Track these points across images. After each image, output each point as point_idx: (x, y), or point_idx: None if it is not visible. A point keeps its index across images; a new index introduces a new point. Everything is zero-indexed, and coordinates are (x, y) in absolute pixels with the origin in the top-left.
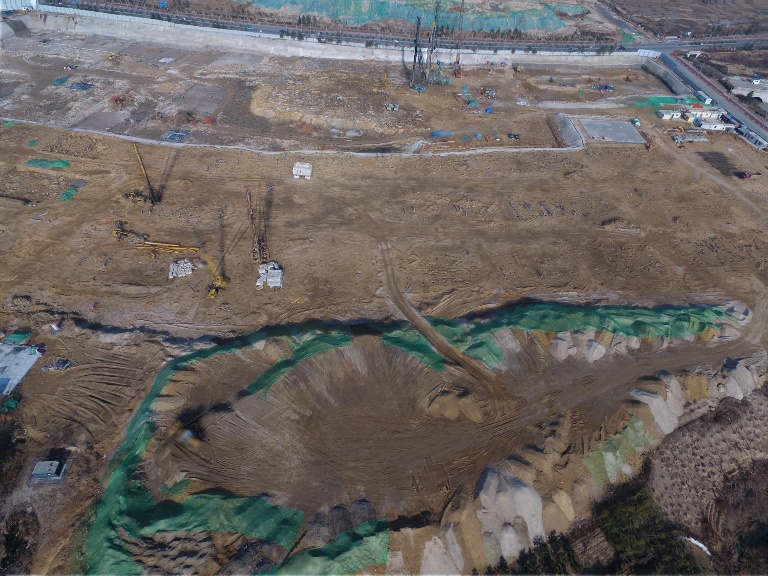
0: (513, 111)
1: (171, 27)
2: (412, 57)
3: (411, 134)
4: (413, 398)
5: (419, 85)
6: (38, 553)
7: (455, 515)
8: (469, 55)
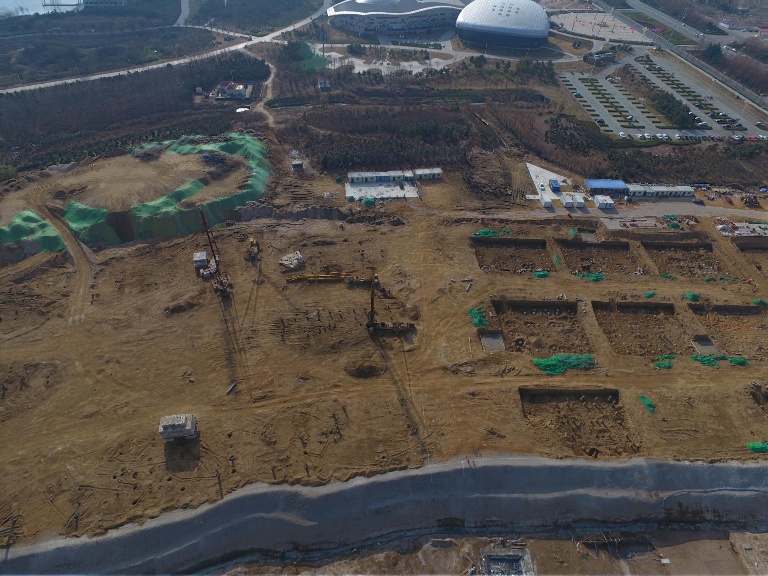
0: None
1: None
2: None
3: None
4: (96, 188)
5: None
6: (283, 153)
7: None
8: None
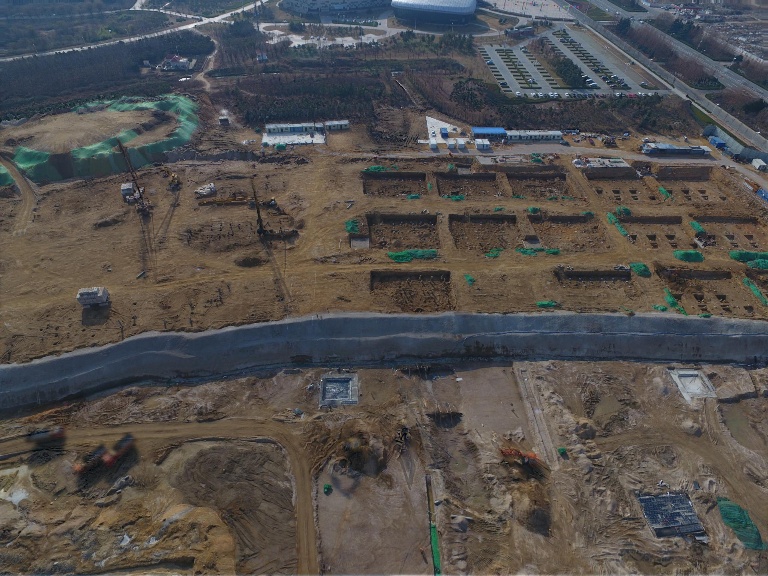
0: None
1: None
2: None
3: None
4: (42, 137)
5: None
6: None
7: None
8: None
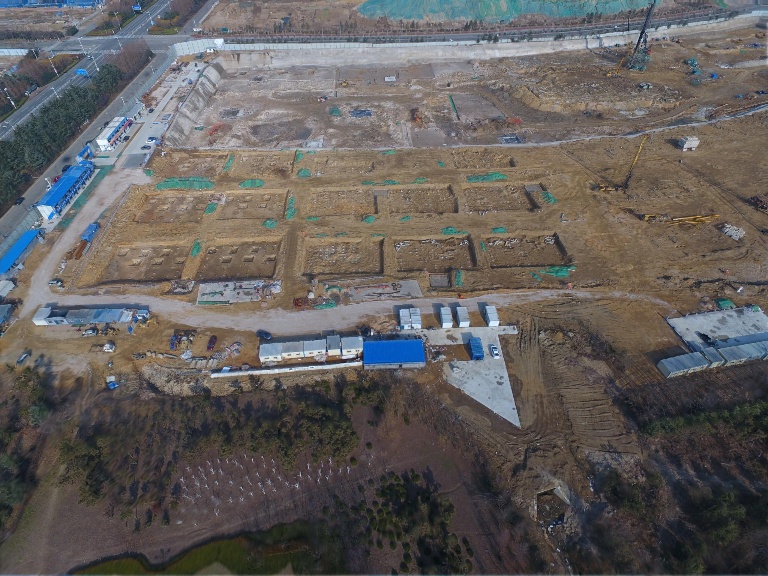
0: (728, 74)
1: (369, 48)
2: (594, 43)
3: (688, 104)
4: None
5: (637, 65)
6: None
7: None
8: (637, 35)
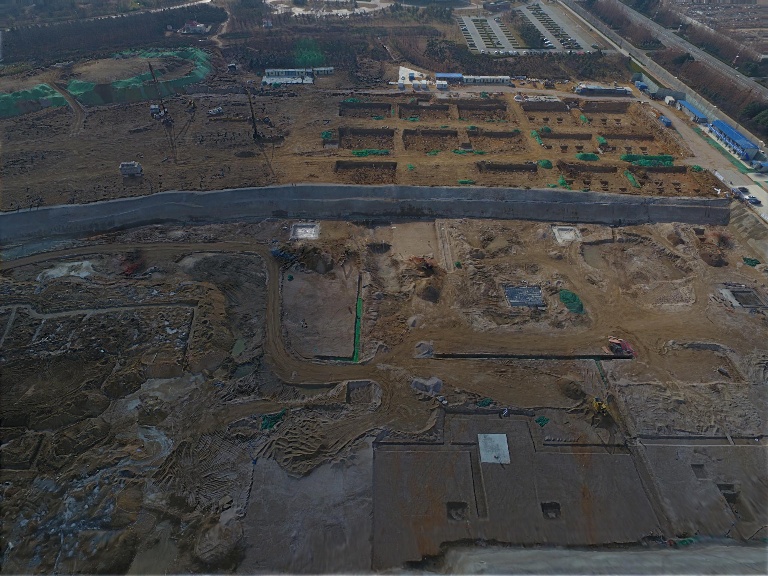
0: None
1: None
2: None
3: None
4: None
5: None
6: None
7: None
8: None
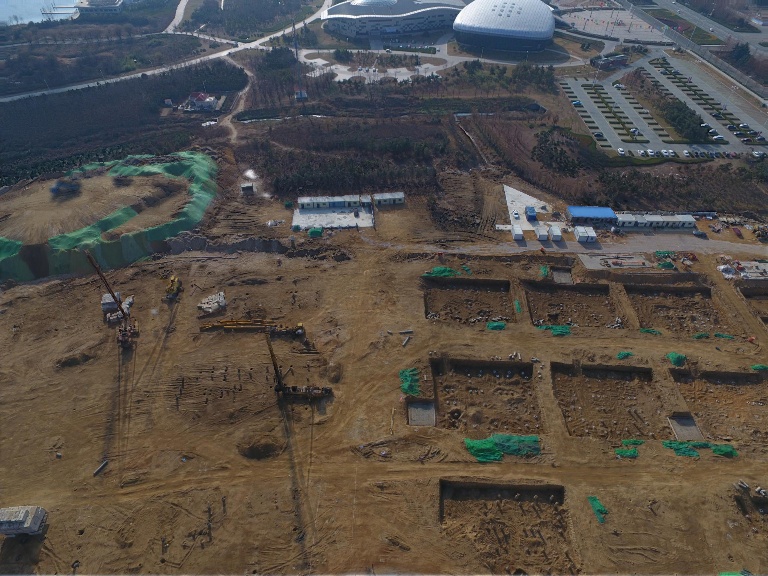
0: None
1: None
2: None
3: None
4: (20, 216)
5: None
6: (237, 173)
7: (28, 180)
8: None
